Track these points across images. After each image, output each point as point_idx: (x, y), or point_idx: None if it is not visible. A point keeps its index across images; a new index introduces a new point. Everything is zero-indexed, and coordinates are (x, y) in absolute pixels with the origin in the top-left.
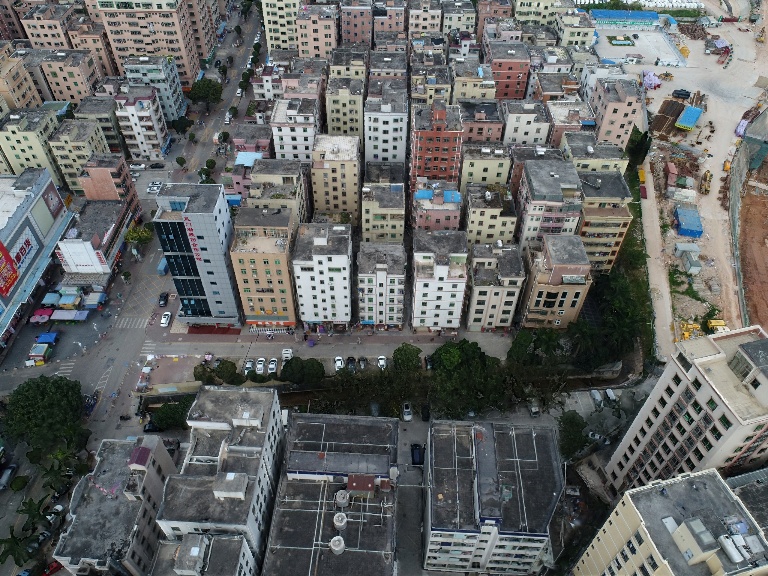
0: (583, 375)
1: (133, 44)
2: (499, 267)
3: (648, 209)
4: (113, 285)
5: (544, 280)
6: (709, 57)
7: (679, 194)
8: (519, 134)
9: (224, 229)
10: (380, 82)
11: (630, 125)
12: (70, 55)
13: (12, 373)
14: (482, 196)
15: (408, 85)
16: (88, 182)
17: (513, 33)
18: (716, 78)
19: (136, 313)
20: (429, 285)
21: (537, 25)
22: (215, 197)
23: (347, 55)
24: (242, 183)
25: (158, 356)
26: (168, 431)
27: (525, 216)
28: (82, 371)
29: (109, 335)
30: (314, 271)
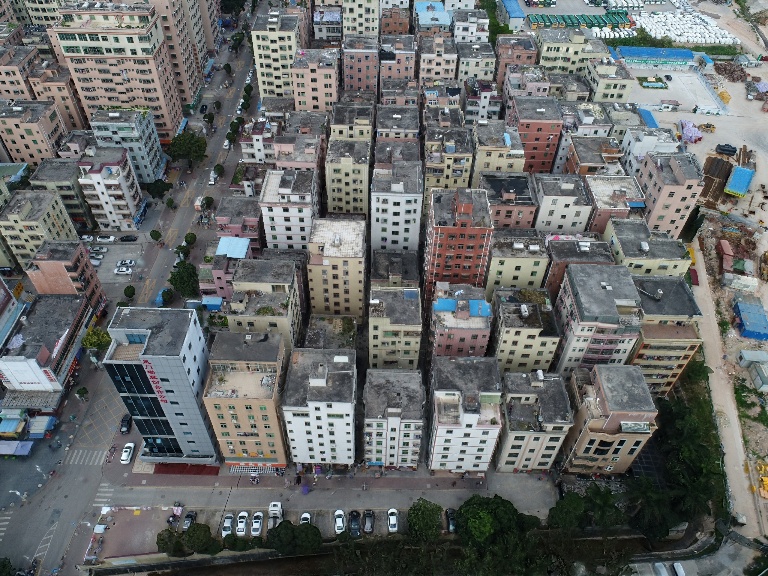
0: (641, 534)
1: (104, 93)
2: (541, 408)
3: (702, 300)
4: (66, 403)
5: (597, 426)
6: (752, 103)
7: (738, 282)
8: (555, 217)
9: (196, 364)
10: (389, 148)
11: (688, 210)
12: (28, 109)
13: None
14: (517, 309)
15: (420, 145)
16: (38, 276)
17: (540, 85)
18: (762, 129)
19: (92, 443)
20: (453, 431)
21: (565, 72)
22: (184, 329)
23: (350, 112)
24: (224, 278)
25: (115, 508)
26: None
27: (569, 334)
28: (19, 529)
29: (57, 475)
30: (309, 417)
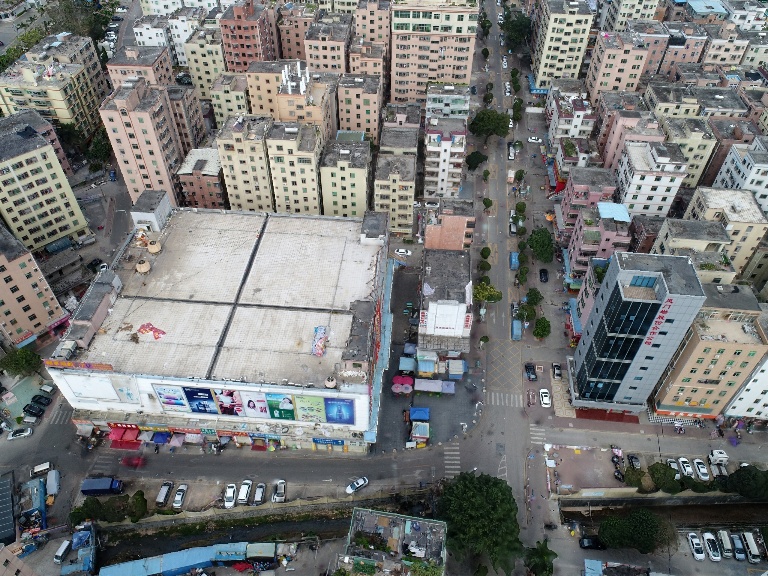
0: None
1: (416, 69)
2: None
3: None
4: None
5: None
6: None
7: None
8: None
9: None
10: (733, 125)
11: None
12: (366, 81)
13: (392, 455)
14: None
15: None
16: (436, 230)
17: None
18: None
19: (504, 387)
20: None
21: None
22: (691, 274)
23: (676, 91)
24: (612, 240)
25: (556, 446)
26: (610, 549)
27: None
28: (472, 459)
29: (485, 413)
30: None
